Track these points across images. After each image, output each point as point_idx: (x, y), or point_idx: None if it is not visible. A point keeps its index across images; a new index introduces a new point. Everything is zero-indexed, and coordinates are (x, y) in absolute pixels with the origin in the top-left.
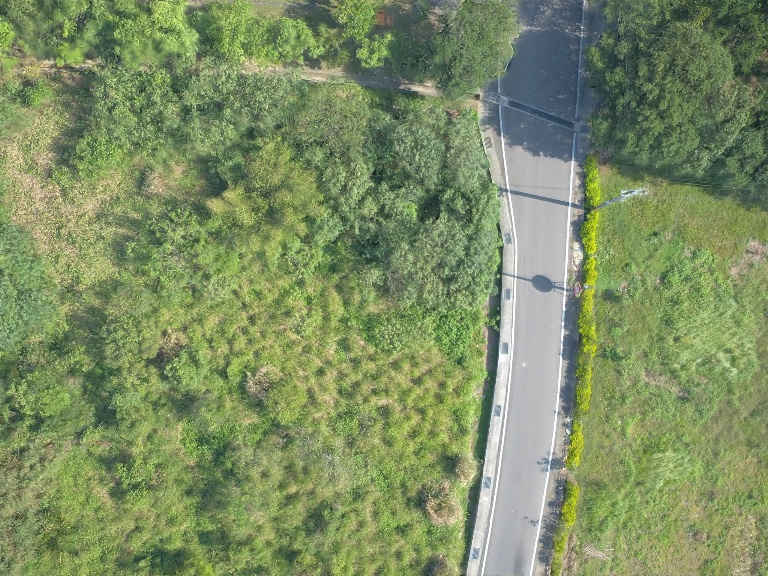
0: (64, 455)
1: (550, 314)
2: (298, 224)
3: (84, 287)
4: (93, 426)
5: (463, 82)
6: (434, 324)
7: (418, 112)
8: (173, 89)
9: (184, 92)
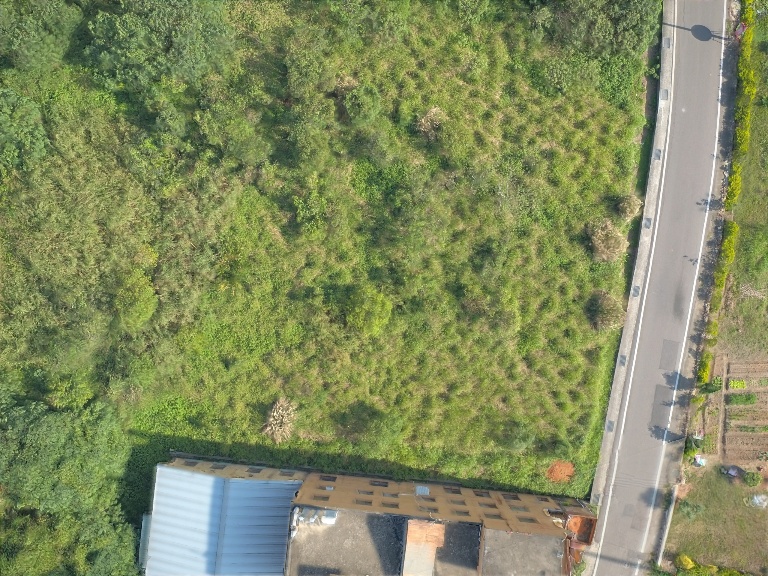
0: (238, 193)
1: (709, 62)
2: None
3: None
4: (269, 162)
5: None
6: None
7: None
8: None
9: None
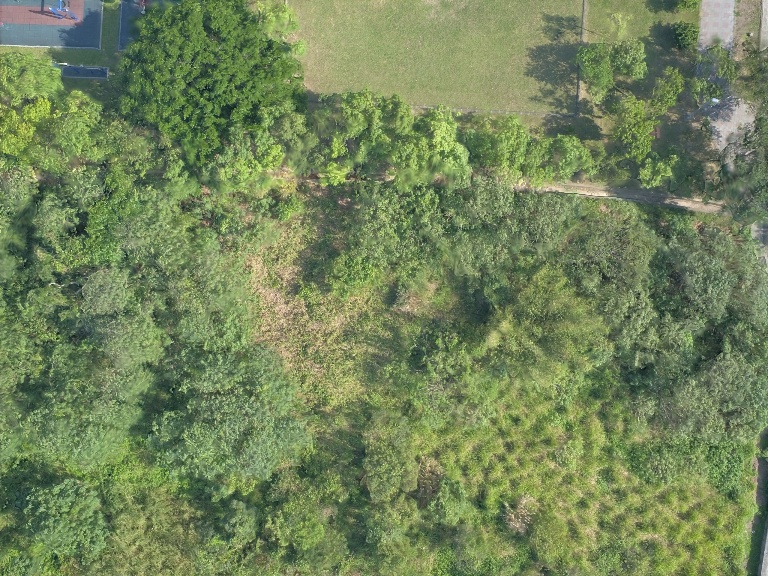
0: None
1: None
2: (580, 358)
3: (331, 408)
4: (345, 557)
5: (765, 211)
6: (703, 455)
7: (691, 231)
8: (442, 210)
9: (451, 212)
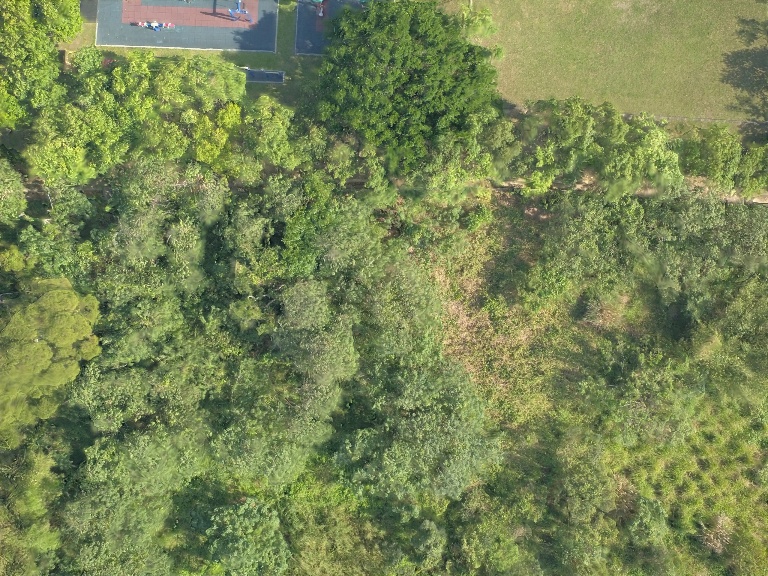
0: None
1: None
2: None
3: (516, 425)
4: None
5: None
6: None
7: None
8: None
9: (653, 223)
